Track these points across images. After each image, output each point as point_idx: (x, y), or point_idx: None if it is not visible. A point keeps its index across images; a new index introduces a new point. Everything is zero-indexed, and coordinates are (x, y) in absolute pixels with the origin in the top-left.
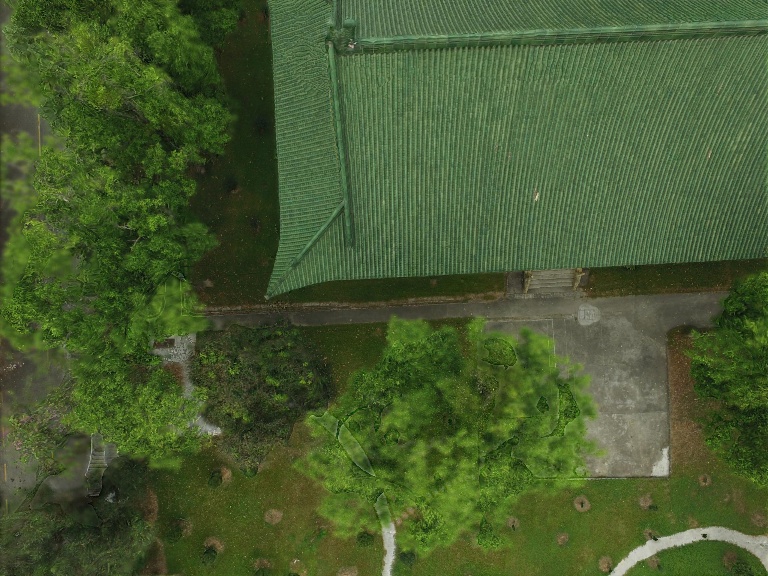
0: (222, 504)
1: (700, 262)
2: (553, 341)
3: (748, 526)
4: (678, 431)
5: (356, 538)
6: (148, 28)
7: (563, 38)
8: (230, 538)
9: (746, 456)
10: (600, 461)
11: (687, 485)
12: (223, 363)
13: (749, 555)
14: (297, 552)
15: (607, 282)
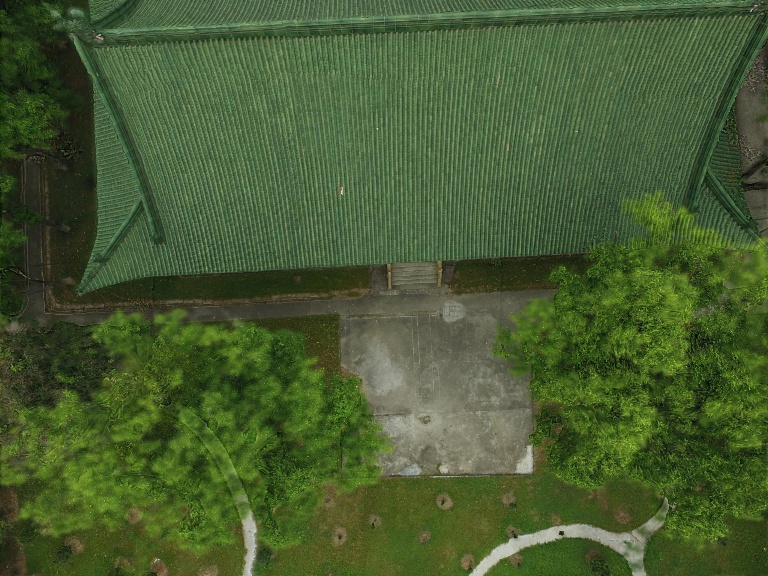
0: (82, 503)
1: (566, 258)
2: (417, 338)
3: (611, 523)
4: None
5: (211, 537)
6: None
7: (317, 29)
8: (90, 537)
9: (556, 452)
10: (464, 458)
11: (550, 482)
12: (7, 360)
13: (612, 553)
14: (157, 551)
15: (472, 278)
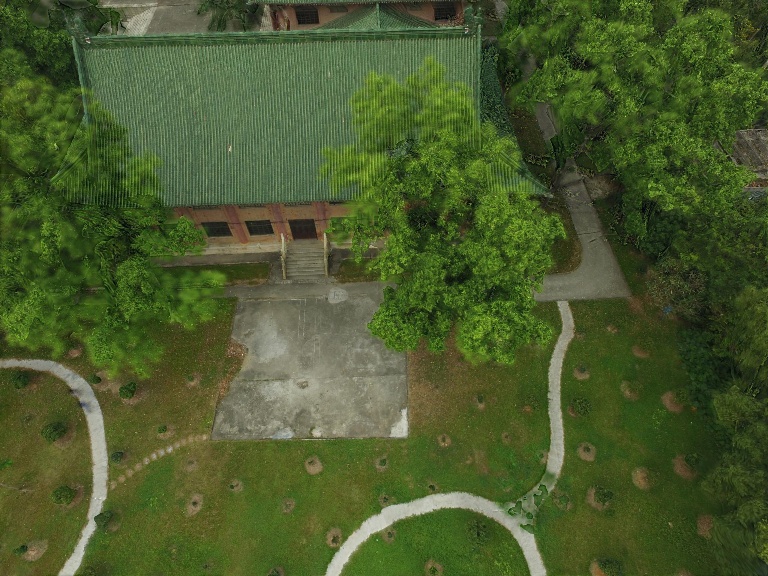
0: None
1: None
2: (304, 315)
3: (493, 491)
4: (416, 391)
5: None
6: (1, 68)
7: (215, 40)
8: None
9: None
10: (338, 422)
11: (425, 445)
12: None
13: (497, 526)
14: None
15: (354, 271)
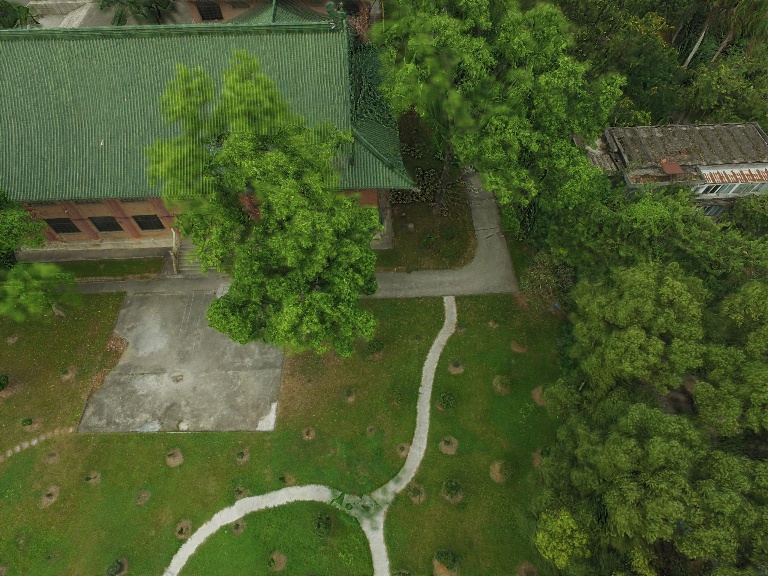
0: None
1: None
2: (189, 310)
3: (349, 483)
4: (288, 385)
5: None
6: None
7: (82, 34)
8: None
9: None
10: (207, 415)
11: (289, 438)
12: None
13: None
14: None
15: None
